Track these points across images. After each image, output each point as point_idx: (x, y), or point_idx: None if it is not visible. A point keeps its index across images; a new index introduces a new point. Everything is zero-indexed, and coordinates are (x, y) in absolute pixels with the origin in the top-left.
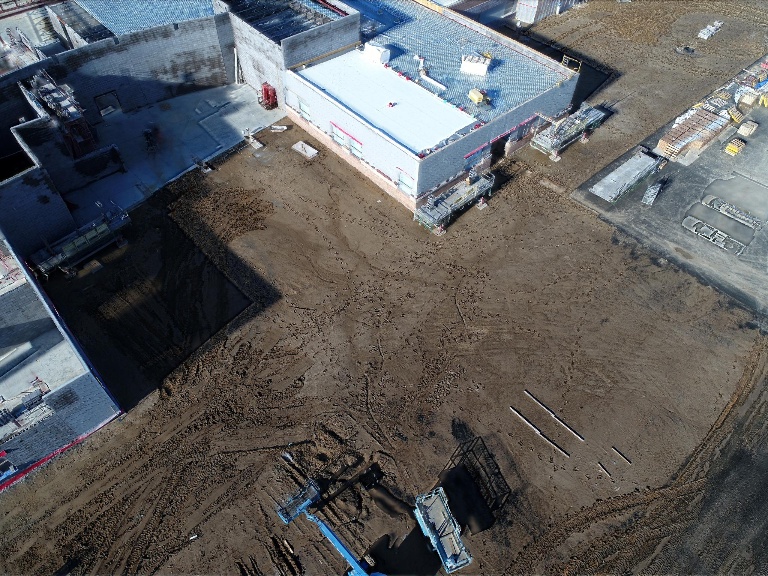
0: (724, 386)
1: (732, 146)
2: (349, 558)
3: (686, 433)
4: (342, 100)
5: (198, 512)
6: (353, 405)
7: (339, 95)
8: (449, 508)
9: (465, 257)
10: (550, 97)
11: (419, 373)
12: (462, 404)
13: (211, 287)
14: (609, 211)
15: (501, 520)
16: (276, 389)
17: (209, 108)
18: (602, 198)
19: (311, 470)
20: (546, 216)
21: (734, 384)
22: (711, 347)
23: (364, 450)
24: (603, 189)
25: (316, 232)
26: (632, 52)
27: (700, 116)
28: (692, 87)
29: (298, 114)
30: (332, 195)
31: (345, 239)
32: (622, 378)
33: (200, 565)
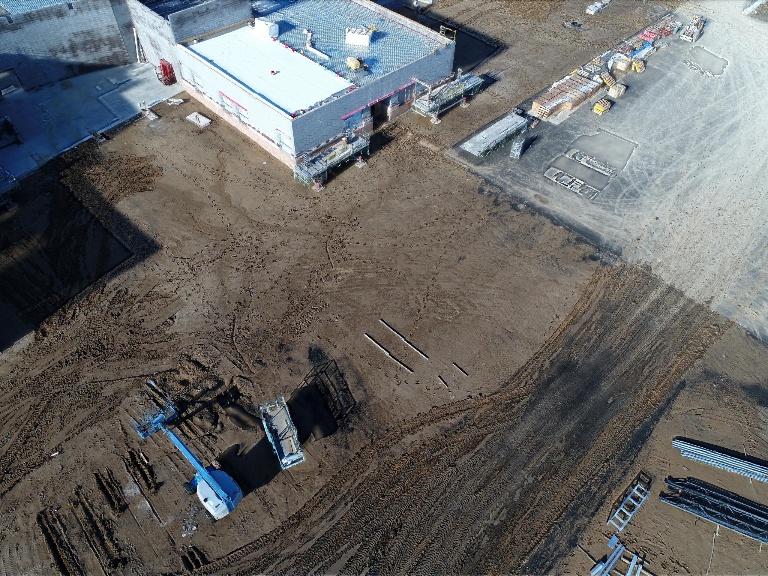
0: (562, 309)
1: (598, 106)
2: (191, 459)
3: (521, 349)
4: (228, 70)
5: (61, 433)
6: (219, 338)
7: (225, 65)
8: (297, 420)
9: (340, 209)
10: (427, 64)
11: (284, 309)
12: (321, 333)
13: (95, 242)
14: (479, 165)
15: (343, 427)
16: (147, 327)
17: (110, 85)
18: (471, 153)
19: (173, 394)
20: (421, 171)
21: (571, 307)
22: (555, 277)
23: (225, 375)
24: (473, 145)
25: (201, 192)
26: (522, 27)
27: (573, 81)
28: (573, 57)
29: (193, 87)
30: (220, 159)
31: (228, 197)
32: (471, 306)
33: (59, 477)
